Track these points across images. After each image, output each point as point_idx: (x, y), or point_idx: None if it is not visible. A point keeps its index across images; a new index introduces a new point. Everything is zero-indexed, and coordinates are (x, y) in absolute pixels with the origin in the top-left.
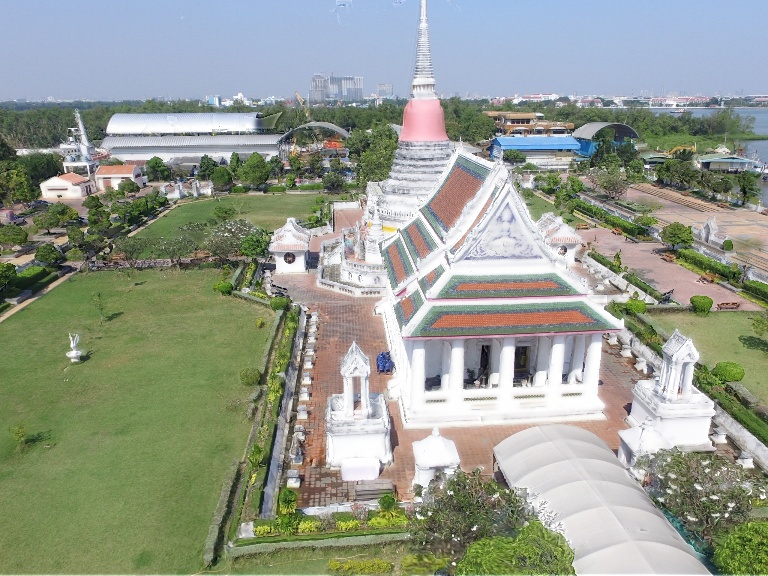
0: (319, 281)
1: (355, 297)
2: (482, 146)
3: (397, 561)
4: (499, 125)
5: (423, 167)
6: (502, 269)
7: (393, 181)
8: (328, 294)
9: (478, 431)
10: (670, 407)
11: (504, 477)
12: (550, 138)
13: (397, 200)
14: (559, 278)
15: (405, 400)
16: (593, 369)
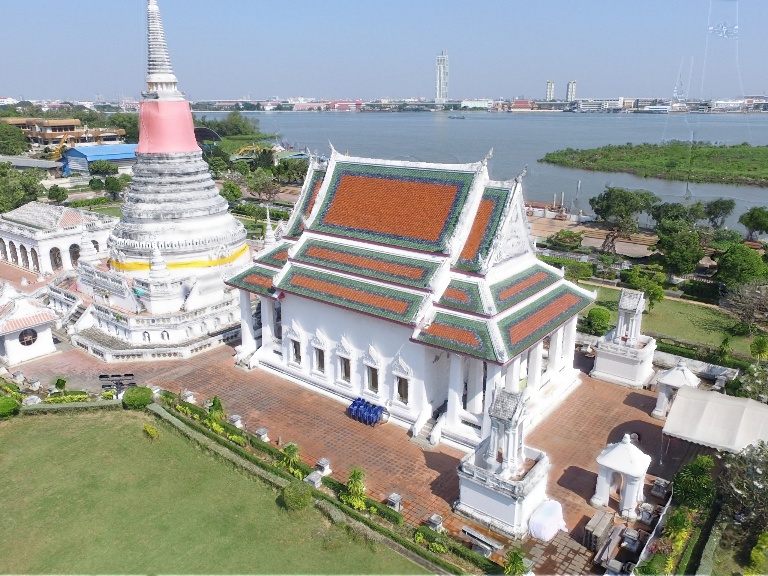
0: (111, 355)
1: (185, 359)
2: (48, 159)
3: (733, 568)
4: (33, 134)
5: (189, 183)
6: (510, 270)
7: (149, 205)
8: (142, 367)
9: (540, 434)
10: (645, 351)
11: (712, 447)
12: (135, 145)
13: (165, 228)
14: (542, 268)
15: (468, 436)
16: (573, 342)
